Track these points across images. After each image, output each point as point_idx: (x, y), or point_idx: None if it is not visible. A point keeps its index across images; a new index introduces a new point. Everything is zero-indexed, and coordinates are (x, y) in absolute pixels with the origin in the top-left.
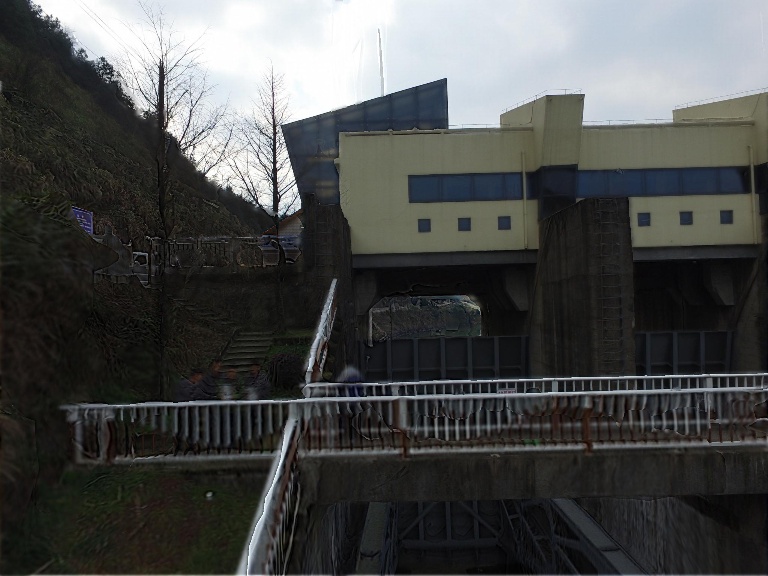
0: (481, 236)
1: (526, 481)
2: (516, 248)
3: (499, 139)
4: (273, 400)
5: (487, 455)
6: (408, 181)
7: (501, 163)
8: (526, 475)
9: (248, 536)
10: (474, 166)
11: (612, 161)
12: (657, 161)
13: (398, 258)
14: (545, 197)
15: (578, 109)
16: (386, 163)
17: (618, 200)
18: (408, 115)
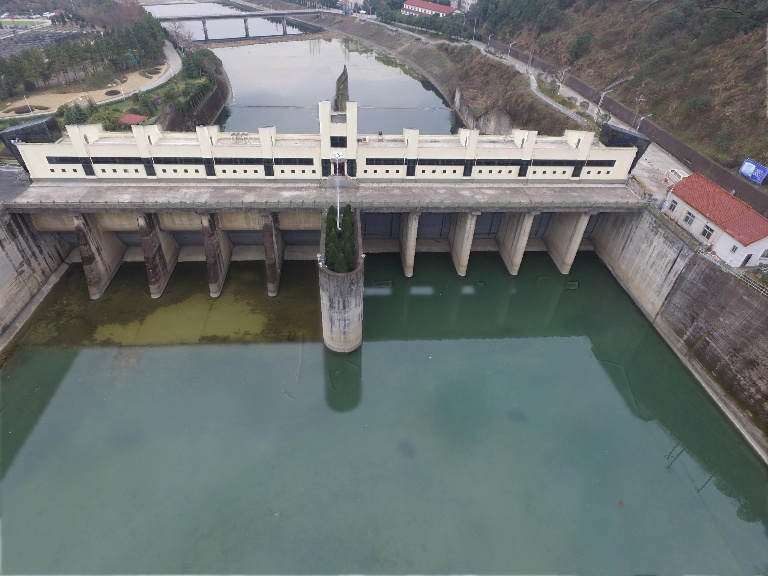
0: None
1: None
2: None
3: None
4: None
5: None
6: None
7: None
8: None
9: None
10: None
11: None
12: None
13: None
14: None
15: None
16: None
17: None
18: None
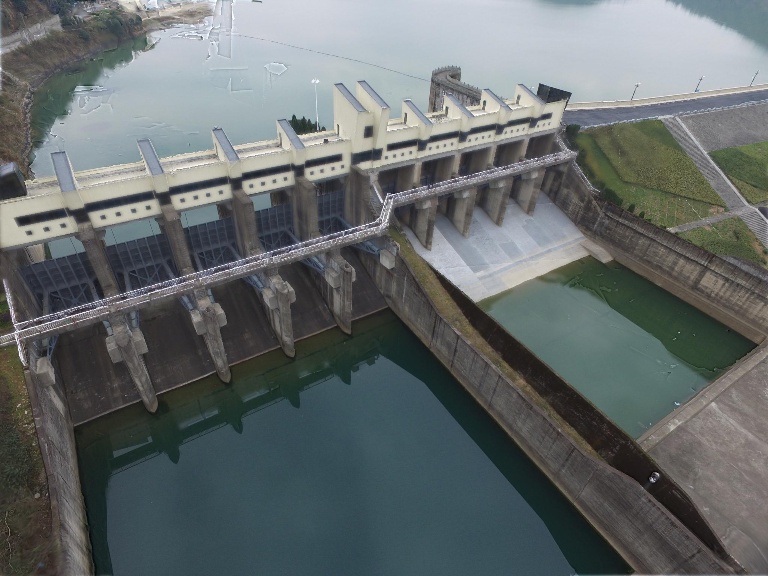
0: (55, 232)
1: None
2: (71, 233)
3: (49, 198)
4: (10, 334)
5: (56, 329)
6: (14, 220)
7: (54, 206)
8: (64, 329)
9: (16, 353)
10: (42, 209)
11: (100, 198)
12: None
13: (22, 245)
14: None
15: (76, 194)
16: (1, 215)
17: (91, 240)
18: (1, 186)
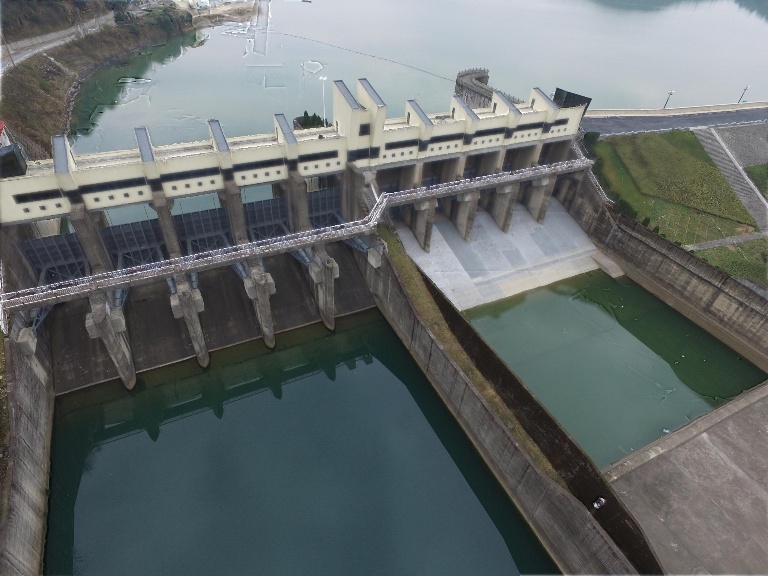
0: (51, 211)
1: (47, 303)
2: (66, 212)
3: (45, 179)
4: None
5: None
6: (12, 197)
7: (49, 186)
8: None
9: None
10: (38, 189)
11: (93, 181)
12: (110, 179)
13: (20, 221)
14: (69, 199)
15: (69, 176)
16: None
17: (80, 220)
18: (2, 165)
